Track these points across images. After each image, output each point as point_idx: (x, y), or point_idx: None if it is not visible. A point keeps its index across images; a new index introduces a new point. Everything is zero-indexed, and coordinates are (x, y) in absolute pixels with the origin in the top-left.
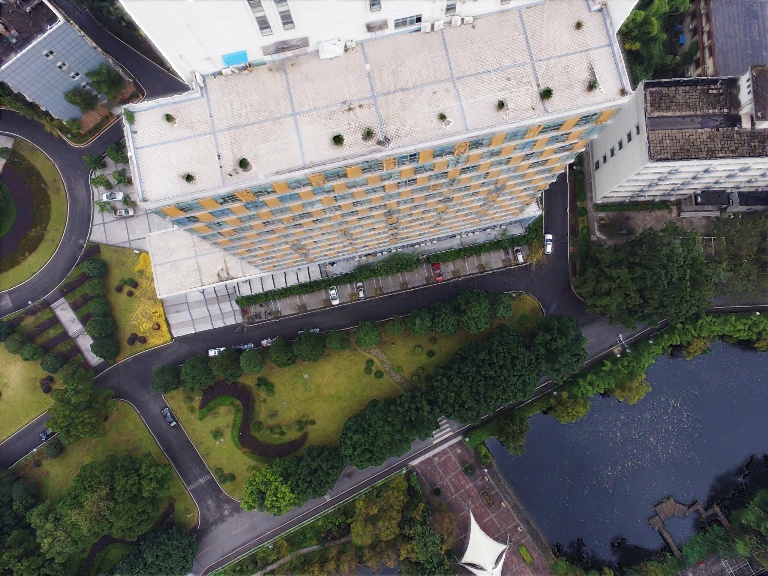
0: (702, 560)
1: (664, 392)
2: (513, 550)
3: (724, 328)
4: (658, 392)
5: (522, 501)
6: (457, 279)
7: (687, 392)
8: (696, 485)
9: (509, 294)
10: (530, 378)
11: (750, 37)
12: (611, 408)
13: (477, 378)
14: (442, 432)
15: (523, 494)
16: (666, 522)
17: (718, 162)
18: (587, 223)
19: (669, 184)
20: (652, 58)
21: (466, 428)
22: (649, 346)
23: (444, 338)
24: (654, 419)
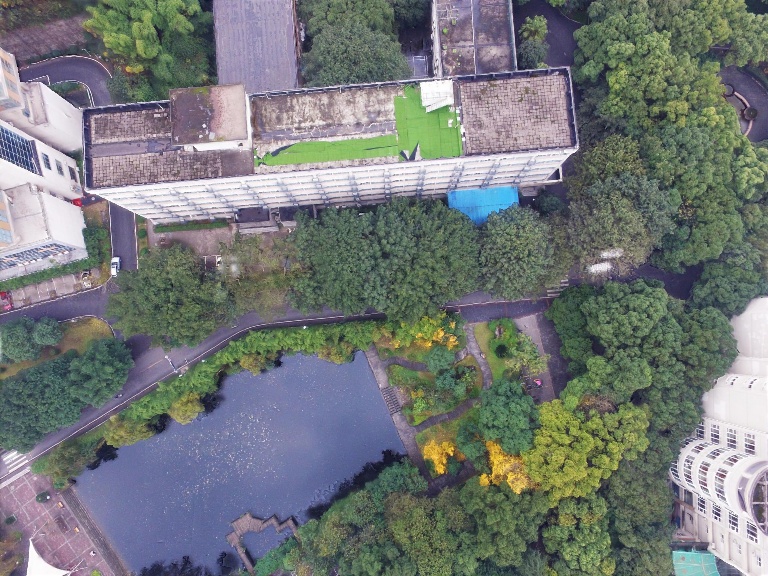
0: (270, 574)
1: (243, 408)
2: (87, 575)
3: (273, 344)
4: (237, 408)
5: (101, 525)
6: (28, 306)
7: (266, 407)
8: (273, 499)
9: (79, 319)
10: (62, 405)
11: (254, 55)
12: (190, 427)
13: (5, 408)
14: (18, 460)
15: (103, 518)
16: (242, 538)
17: (161, 186)
18: (147, 245)
19: (187, 205)
20: (165, 79)
21: (39, 455)
22: (202, 365)
23: (15, 366)
24: (233, 436)
